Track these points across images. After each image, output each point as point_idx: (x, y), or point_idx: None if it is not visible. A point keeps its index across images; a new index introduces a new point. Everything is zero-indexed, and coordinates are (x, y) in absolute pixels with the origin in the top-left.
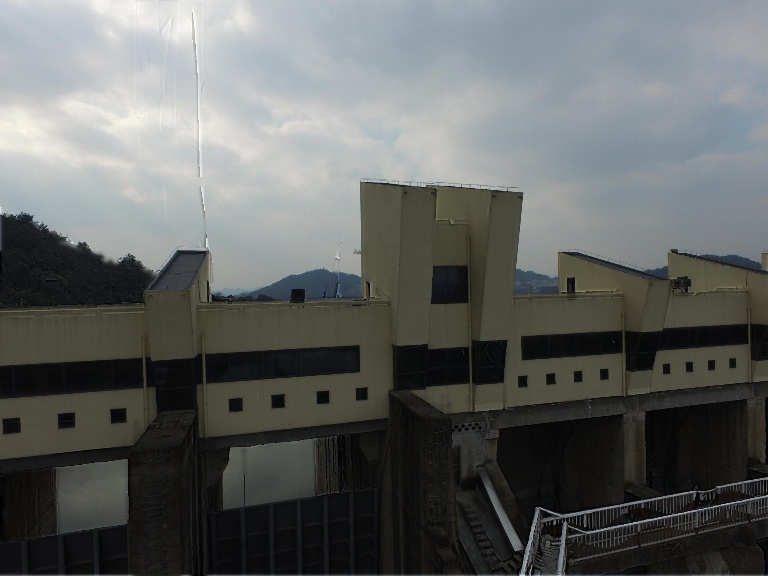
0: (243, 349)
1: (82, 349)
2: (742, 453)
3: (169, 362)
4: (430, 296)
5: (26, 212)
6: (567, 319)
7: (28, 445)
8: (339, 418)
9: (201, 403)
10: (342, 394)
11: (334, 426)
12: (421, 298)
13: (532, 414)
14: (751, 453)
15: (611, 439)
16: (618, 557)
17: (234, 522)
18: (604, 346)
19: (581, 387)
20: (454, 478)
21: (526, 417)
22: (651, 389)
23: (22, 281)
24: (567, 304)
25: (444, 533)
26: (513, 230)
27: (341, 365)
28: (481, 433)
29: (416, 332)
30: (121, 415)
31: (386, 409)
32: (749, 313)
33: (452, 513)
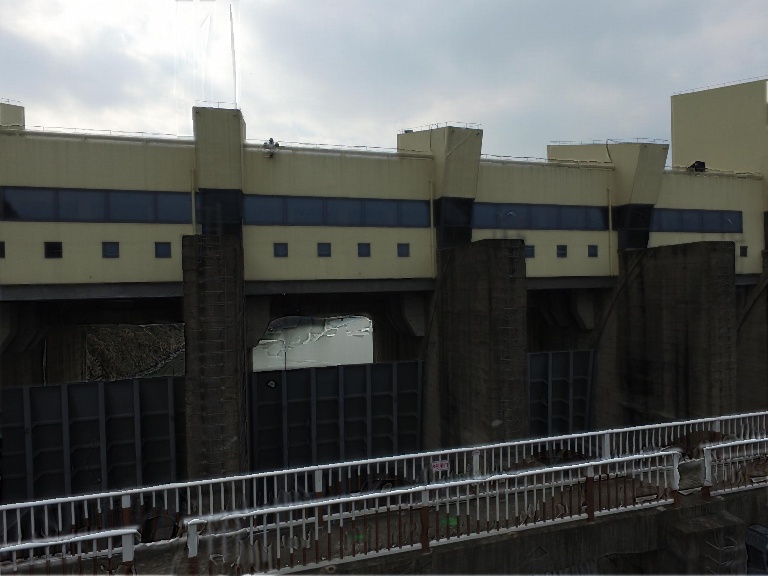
0: (668, 206)
1: (570, 195)
2: None
3: (640, 206)
4: None
5: None
6: None
7: (538, 268)
8: None
9: None
10: None
11: None
12: None
13: None
14: None
15: None
16: None
17: None
18: None
19: None
20: None
21: None
22: None
23: None
24: None
25: None
26: None
27: (727, 227)
28: None
29: None
30: (593, 251)
31: (760, 266)
32: None
33: None
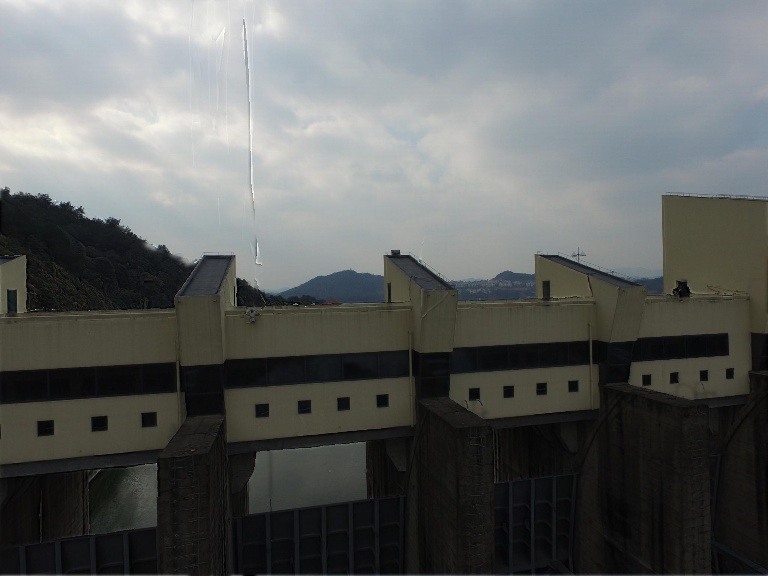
0: (651, 335)
1: (550, 333)
2: None
3: (620, 344)
4: None
5: (114, 217)
6: None
7: (518, 407)
8: (714, 393)
9: None
10: (716, 373)
11: (710, 400)
12: None
13: None
14: None
15: None
16: None
17: None
18: None
19: None
20: None
21: None
22: None
23: (123, 282)
24: None
25: None
26: None
27: (712, 349)
28: None
29: None
30: (574, 386)
31: (747, 387)
32: None
33: None
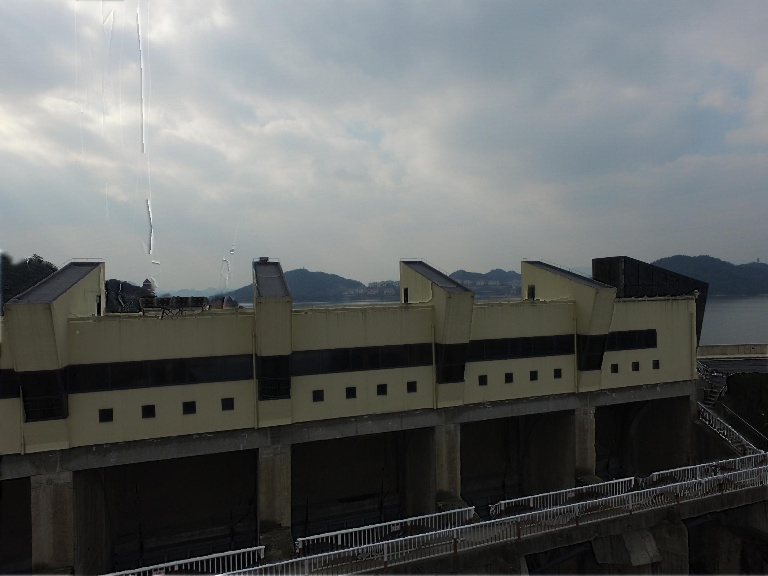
0: None
1: None
2: (258, 515)
3: None
4: None
5: None
6: None
7: None
8: None
9: None
10: None
11: None
12: None
13: None
14: (265, 515)
15: None
16: None
17: None
18: None
19: None
20: None
21: None
22: (75, 443)
23: None
24: None
25: None
26: None
27: None
28: None
29: None
30: None
31: None
32: (253, 340)
33: None
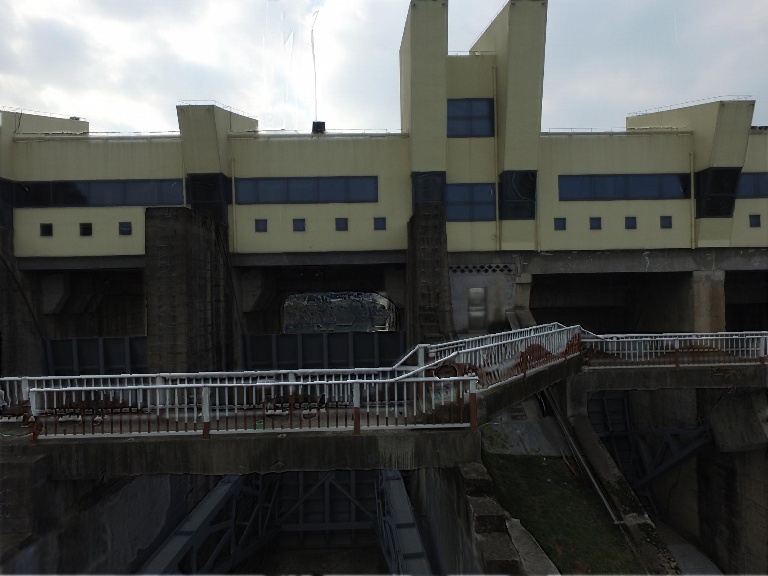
0: (268, 175)
1: (137, 169)
2: None
3: (200, 176)
4: (445, 118)
5: None
6: (616, 158)
7: (97, 246)
8: (357, 246)
9: (231, 221)
10: (360, 223)
11: (353, 254)
12: (436, 121)
13: (572, 262)
14: None
15: (680, 305)
16: (647, 373)
17: (267, 346)
18: (666, 190)
19: (635, 235)
20: (480, 321)
21: (565, 264)
22: (732, 243)
23: None
24: (616, 141)
25: (433, 313)
26: (538, 43)
27: (360, 196)
28: (511, 276)
29: (432, 158)
30: None
31: (405, 240)
32: None
33: (446, 302)
